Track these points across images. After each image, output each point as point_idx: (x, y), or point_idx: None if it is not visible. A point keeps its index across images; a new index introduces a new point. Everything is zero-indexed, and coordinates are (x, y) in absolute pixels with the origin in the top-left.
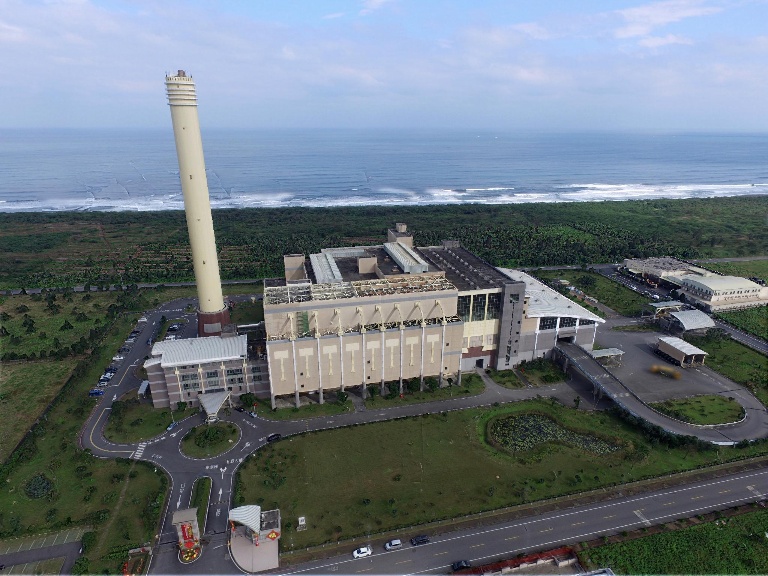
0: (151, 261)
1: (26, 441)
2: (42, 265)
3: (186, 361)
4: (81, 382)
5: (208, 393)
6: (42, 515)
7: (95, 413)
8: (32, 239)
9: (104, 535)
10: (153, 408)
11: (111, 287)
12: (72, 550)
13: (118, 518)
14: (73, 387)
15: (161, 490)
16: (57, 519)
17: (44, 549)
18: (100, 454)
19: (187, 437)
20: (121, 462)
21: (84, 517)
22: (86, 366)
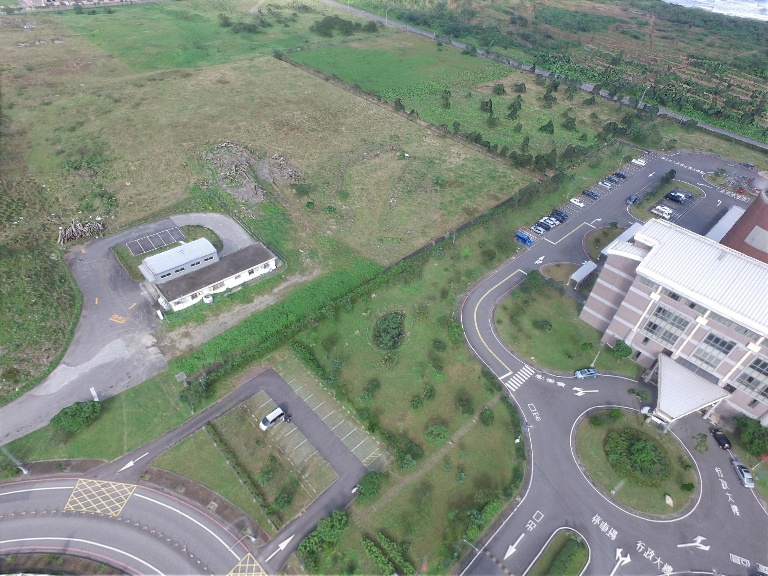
0: (694, 83)
1: (419, 256)
2: (568, 46)
3: (689, 289)
4: (518, 211)
5: (682, 365)
6: (364, 378)
7: (505, 268)
8: (576, 16)
9: (392, 492)
10: (577, 316)
11: (624, 99)
12: (350, 474)
13: (424, 480)
14: (505, 213)
15: (503, 491)
16: (370, 403)
17: (332, 436)
18: (472, 339)
19: (597, 421)
20: (486, 378)
21: (394, 431)
22: (536, 192)
